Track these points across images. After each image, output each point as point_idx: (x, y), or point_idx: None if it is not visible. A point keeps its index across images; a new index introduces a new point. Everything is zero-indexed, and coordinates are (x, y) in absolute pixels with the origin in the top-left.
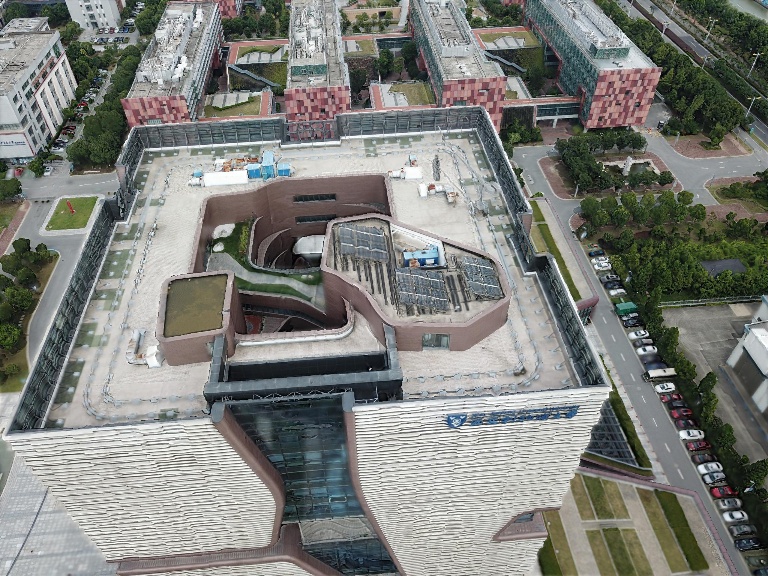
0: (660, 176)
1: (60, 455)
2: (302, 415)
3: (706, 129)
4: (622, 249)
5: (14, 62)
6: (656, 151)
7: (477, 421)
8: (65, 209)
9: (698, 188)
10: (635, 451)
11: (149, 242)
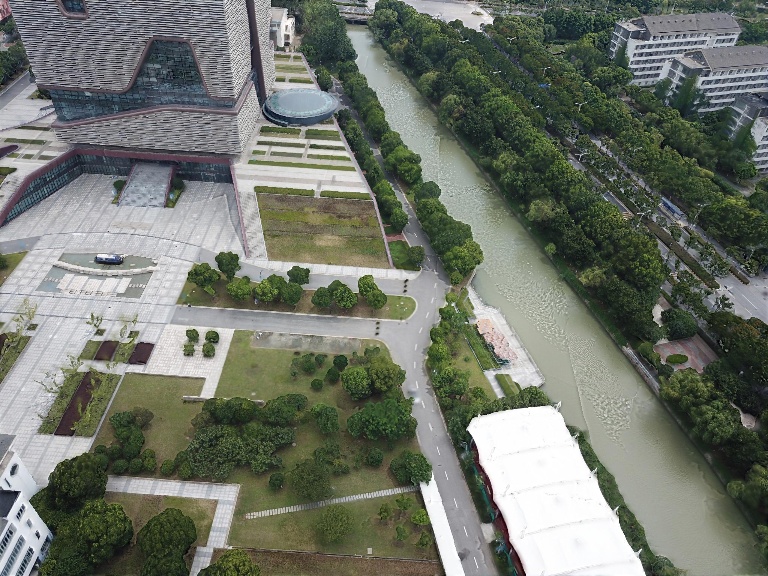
0: None
1: None
2: None
3: None
4: None
5: None
6: None
7: None
8: None
9: None
10: None
11: None
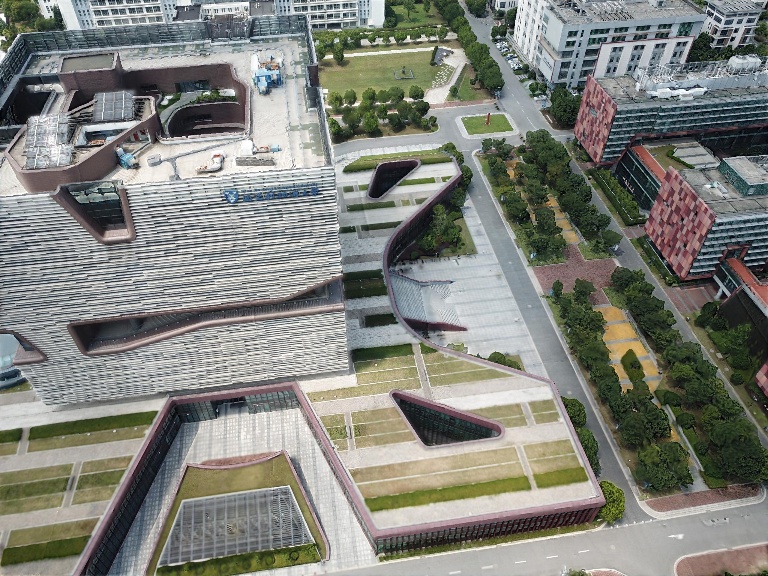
0: None
1: None
2: None
3: None
4: None
5: (629, 14)
6: None
7: None
8: (490, 119)
9: None
10: (176, 567)
11: (188, 55)
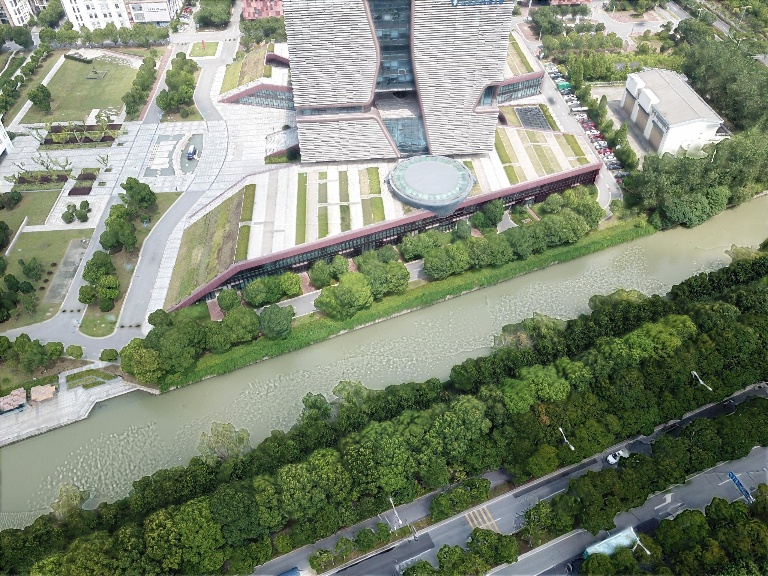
0: (596, 25)
1: (299, 11)
2: (393, 1)
3: None
4: (565, 60)
5: None
6: (599, 19)
7: (463, 2)
8: (199, 47)
9: (623, 37)
10: None
11: None
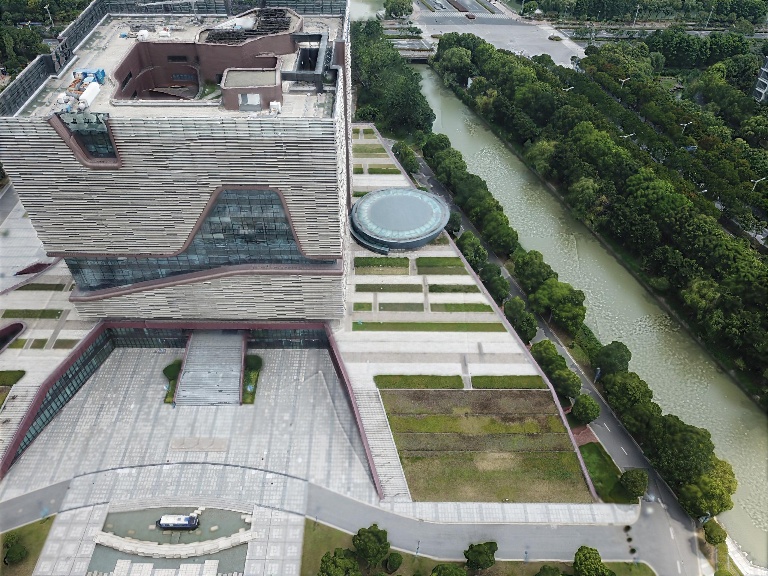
0: None
1: None
2: None
3: (28, 58)
4: None
5: None
6: None
7: None
8: None
9: None
10: None
11: None
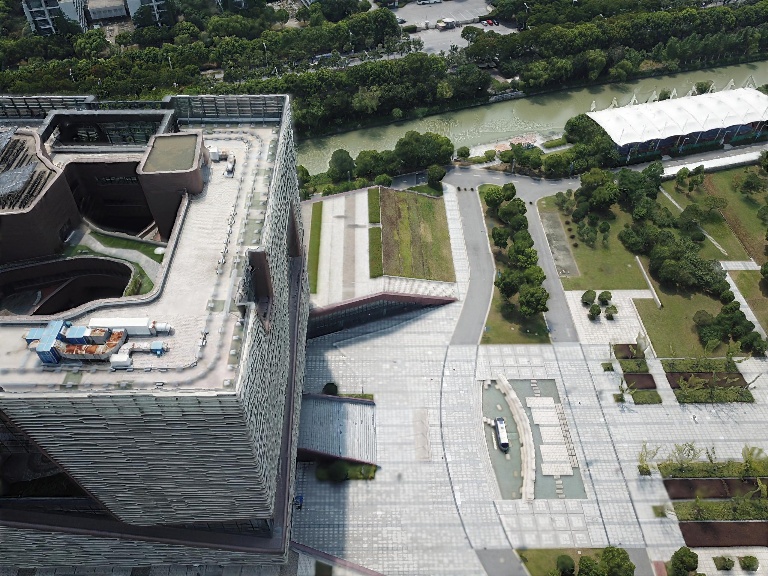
0: None
1: None
2: None
3: None
4: None
5: None
6: None
7: None
8: None
9: None
10: None
11: None
